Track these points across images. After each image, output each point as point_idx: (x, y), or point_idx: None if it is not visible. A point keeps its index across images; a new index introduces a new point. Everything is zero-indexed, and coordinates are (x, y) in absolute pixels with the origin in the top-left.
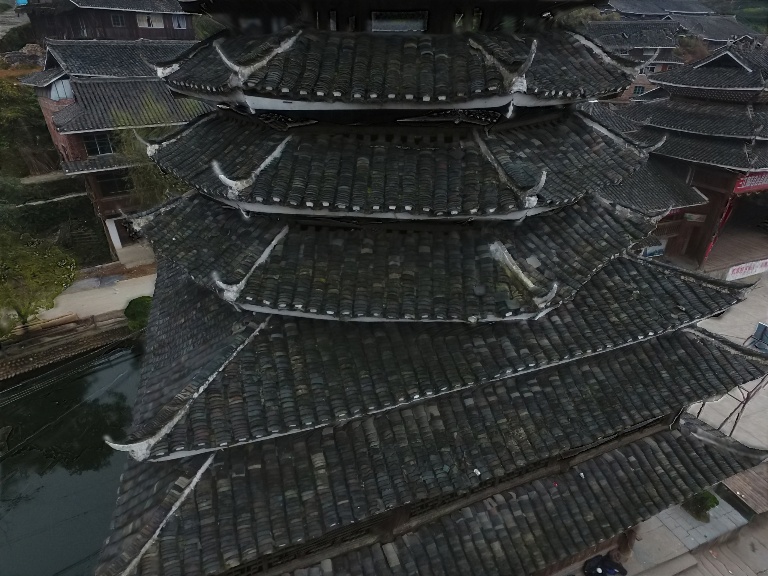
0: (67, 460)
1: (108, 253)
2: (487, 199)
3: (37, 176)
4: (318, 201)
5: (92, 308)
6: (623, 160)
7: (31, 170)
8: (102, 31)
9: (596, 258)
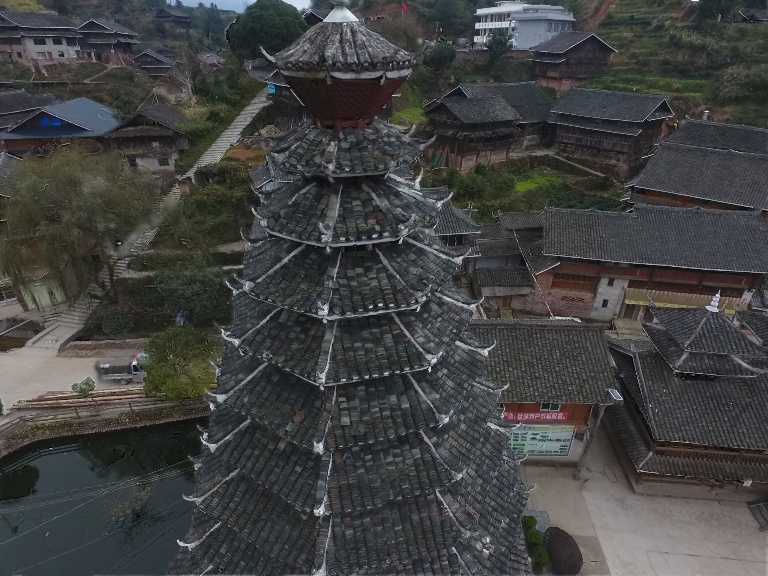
0: None
1: None
2: None
3: None
4: (224, 571)
5: None
6: None
7: None
8: None
9: None
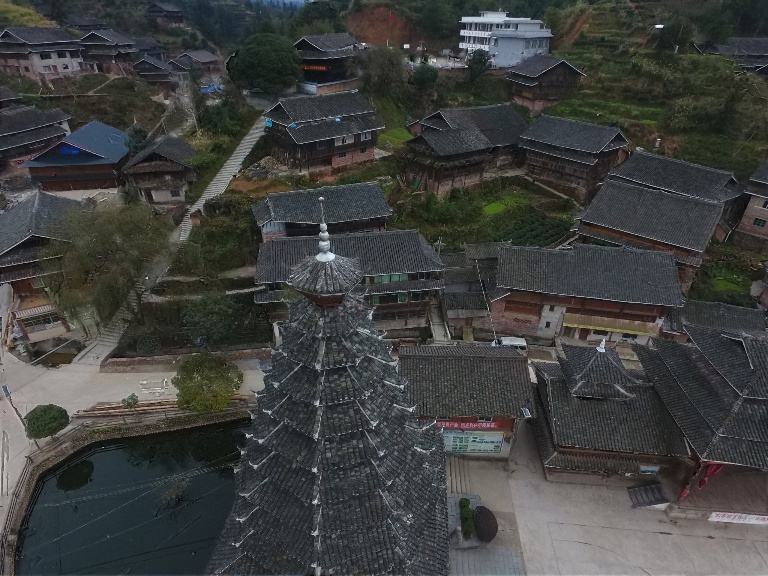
0: (220, 472)
1: (272, 337)
2: (304, 557)
3: (249, 267)
4: None
5: (250, 387)
6: (389, 539)
7: (246, 263)
8: (310, 154)
9: (365, 573)
